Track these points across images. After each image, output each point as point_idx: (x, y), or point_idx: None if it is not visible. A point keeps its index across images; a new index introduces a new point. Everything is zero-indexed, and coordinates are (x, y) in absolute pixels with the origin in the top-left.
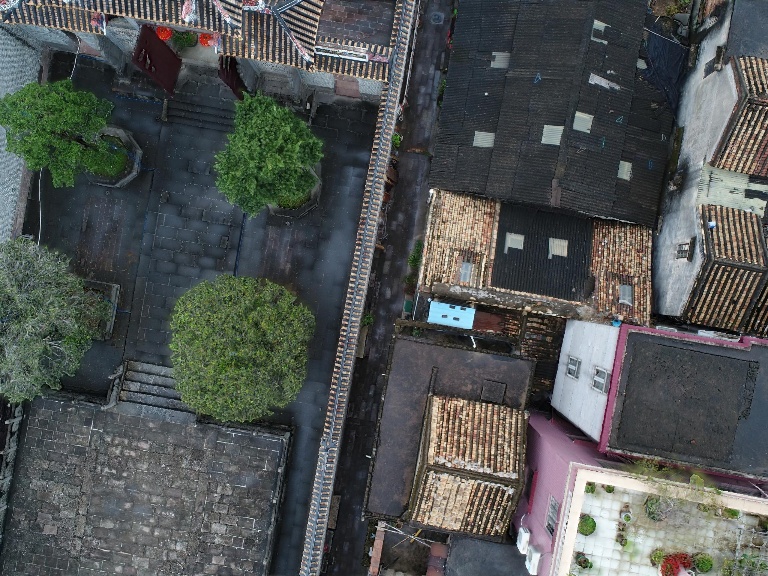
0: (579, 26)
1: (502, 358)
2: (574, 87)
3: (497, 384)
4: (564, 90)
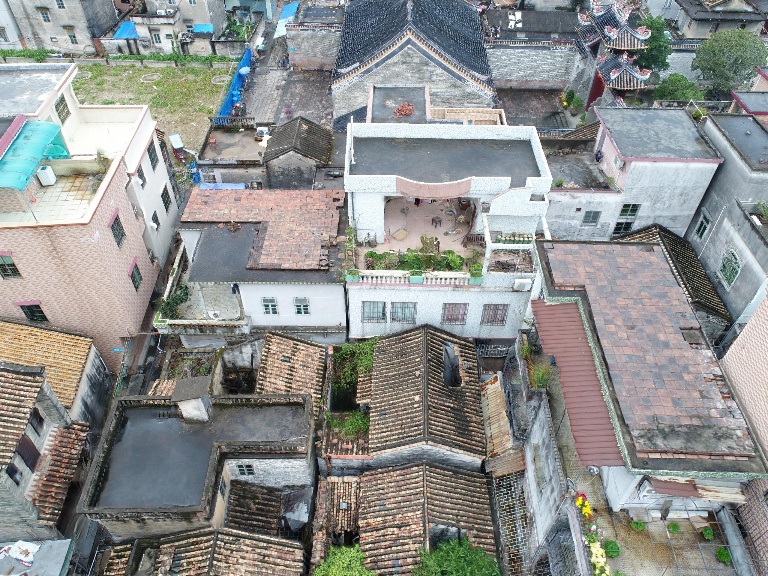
0: (538, 14)
1: (681, 3)
2: (563, 13)
3: (692, 2)
4: (564, 16)
